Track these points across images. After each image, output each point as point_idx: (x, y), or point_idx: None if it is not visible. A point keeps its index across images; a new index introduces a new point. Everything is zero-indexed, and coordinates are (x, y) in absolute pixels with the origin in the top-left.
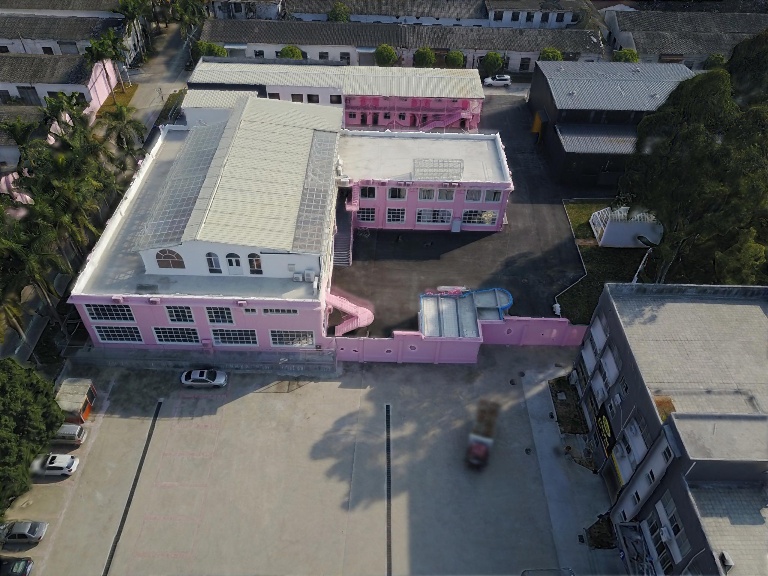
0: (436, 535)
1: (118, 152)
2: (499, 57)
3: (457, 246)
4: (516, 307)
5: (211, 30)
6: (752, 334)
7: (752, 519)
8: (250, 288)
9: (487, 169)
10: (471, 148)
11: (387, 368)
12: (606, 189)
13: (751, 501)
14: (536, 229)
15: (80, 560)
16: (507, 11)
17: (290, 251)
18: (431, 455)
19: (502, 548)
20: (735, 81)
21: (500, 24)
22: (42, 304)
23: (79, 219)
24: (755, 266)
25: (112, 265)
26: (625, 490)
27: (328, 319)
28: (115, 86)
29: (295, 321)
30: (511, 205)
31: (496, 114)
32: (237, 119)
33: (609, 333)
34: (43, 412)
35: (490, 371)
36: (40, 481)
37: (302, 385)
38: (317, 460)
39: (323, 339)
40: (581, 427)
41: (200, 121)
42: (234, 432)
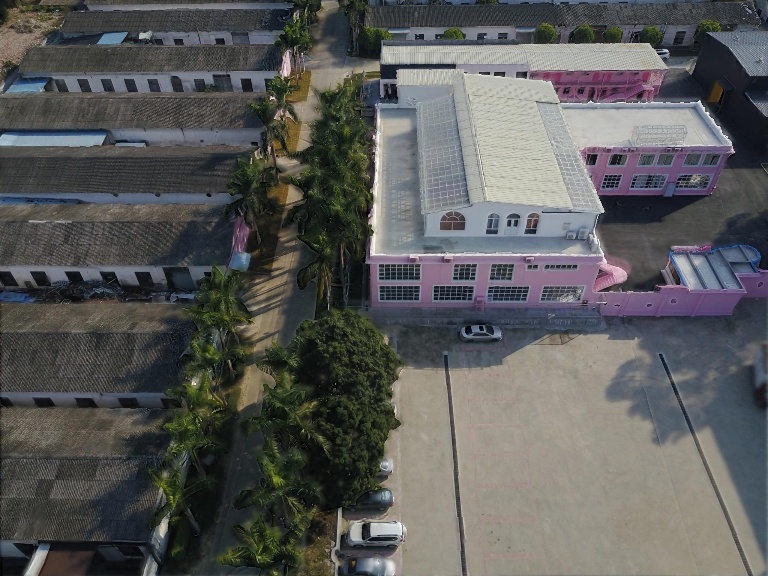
0: (753, 467)
1: (351, 129)
2: (658, 31)
3: (674, 209)
4: None
5: (373, 16)
6: None
7: None
8: (529, 246)
9: (700, 134)
10: (676, 116)
11: (647, 321)
12: None
13: None
14: (745, 192)
15: (431, 491)
16: None
17: (572, 210)
18: (720, 397)
19: None
20: None
21: (646, 0)
22: None
23: None
24: None
25: (390, 229)
26: None
27: None
28: (290, 73)
29: (571, 276)
30: None
31: (665, 86)
32: (463, 94)
33: None
34: None
35: (748, 322)
36: None
37: (573, 338)
38: (614, 403)
39: (592, 294)
40: None
41: None
42: (527, 380)
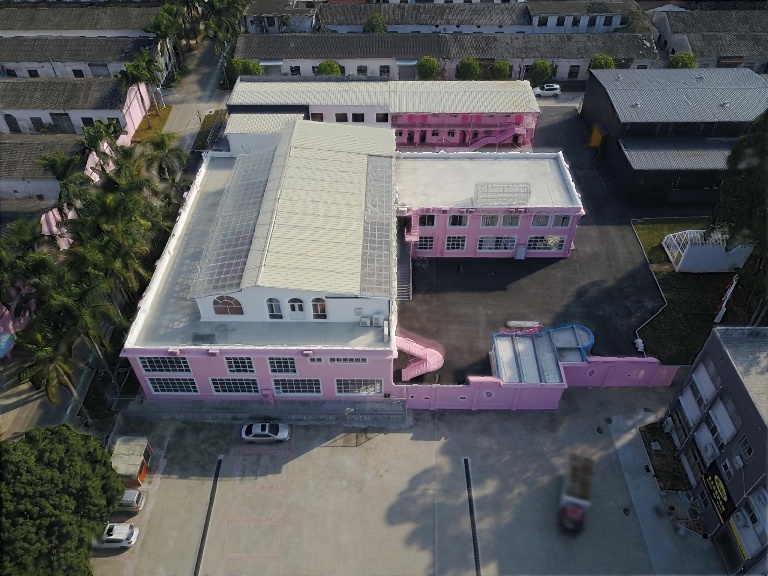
0: None
1: (162, 184)
2: (547, 66)
3: (523, 275)
4: (594, 343)
5: (245, 46)
6: None
7: None
8: (314, 335)
9: (553, 192)
10: (533, 168)
11: (461, 416)
12: (676, 207)
13: None
14: (606, 254)
15: None
16: (552, 16)
17: (358, 295)
18: (519, 518)
19: None
20: None
21: (544, 30)
22: (89, 351)
23: (128, 263)
24: None
25: (164, 311)
26: (754, 567)
27: (393, 362)
28: (149, 108)
29: (363, 370)
30: (576, 227)
31: (548, 127)
32: (286, 146)
33: (721, 384)
34: (103, 484)
35: (574, 418)
36: (98, 554)
37: (371, 437)
38: (395, 525)
39: (392, 387)
40: (682, 483)
41: (243, 146)
42: (302, 494)
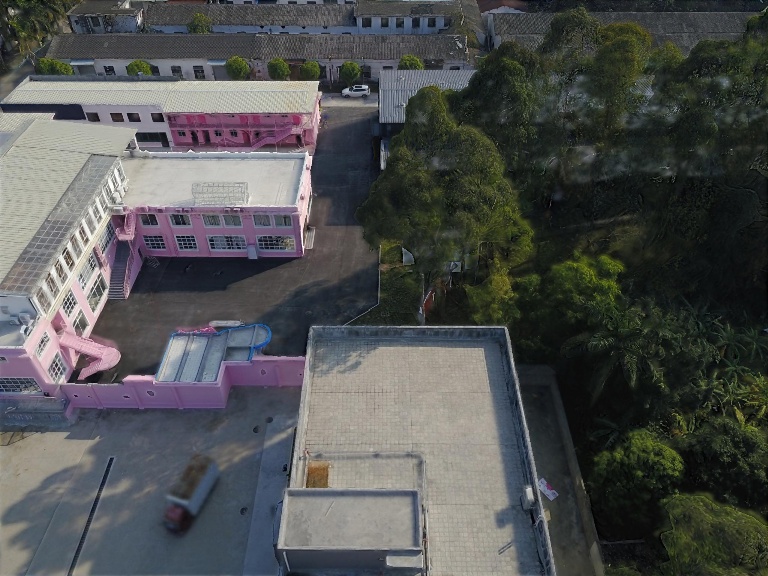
0: None
1: None
2: (355, 66)
3: (250, 275)
4: (288, 343)
5: (59, 46)
6: (459, 383)
7: None
8: None
9: (282, 191)
10: (275, 168)
11: (126, 415)
12: None
13: None
14: (341, 254)
15: None
16: (375, 17)
17: None
18: (137, 516)
19: None
20: (474, 97)
21: (370, 31)
22: None
23: None
24: (507, 300)
25: None
26: None
27: (77, 360)
28: None
29: (10, 368)
30: (324, 227)
31: (342, 127)
32: (9, 145)
33: None
34: None
35: (237, 417)
36: None
37: (26, 436)
38: (9, 524)
39: (49, 386)
40: None
41: None
42: None
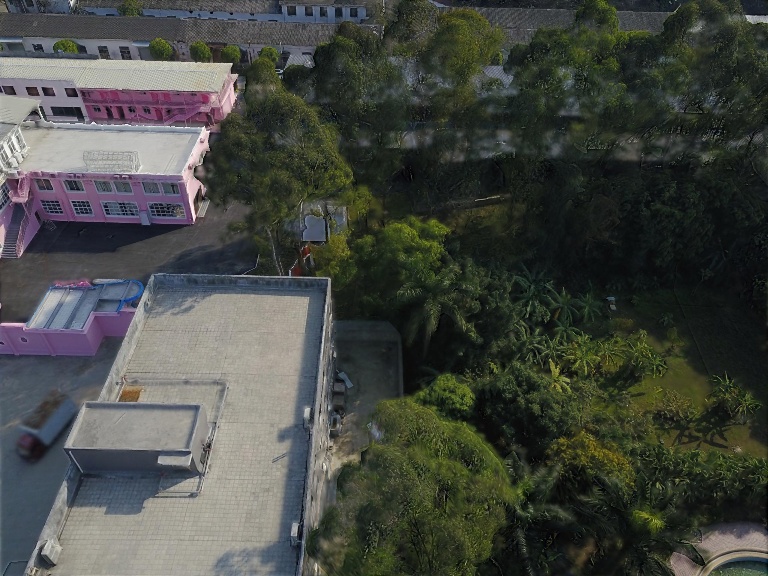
0: None
1: None
2: (274, 51)
3: (140, 239)
4: None
5: None
6: (279, 325)
7: (129, 509)
8: None
9: (173, 162)
10: (171, 141)
11: (2, 360)
12: None
13: (143, 491)
14: (230, 222)
15: None
16: (299, 6)
17: None
18: None
19: (10, 540)
20: (317, 71)
21: (295, 19)
22: None
23: None
24: (346, 258)
25: None
26: None
27: None
28: None
29: None
30: None
31: None
32: None
33: None
34: None
35: (104, 363)
36: None
37: None
38: None
39: None
40: None
41: None
42: None
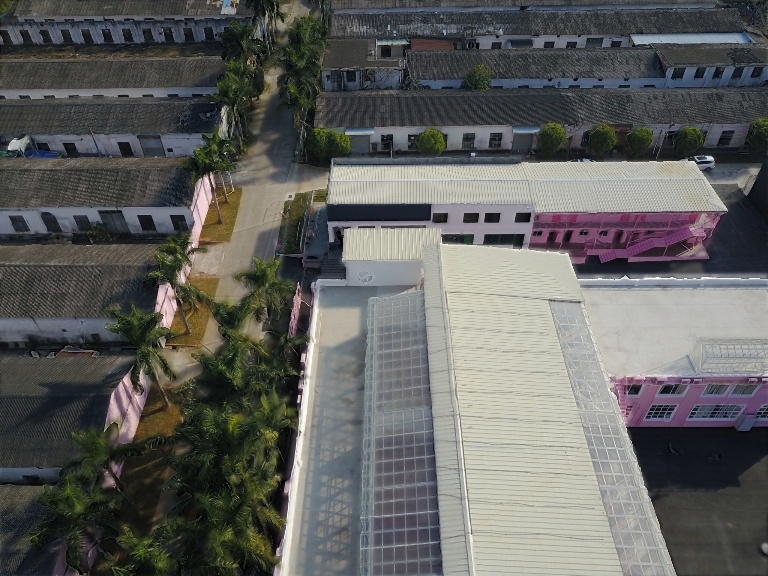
0: None
1: (269, 342)
2: (700, 134)
3: (755, 458)
4: None
5: (326, 111)
6: None
7: None
8: None
9: None
10: (750, 303)
11: None
12: None
13: None
14: None
15: None
16: (691, 67)
17: None
18: None
19: None
20: None
21: (679, 83)
22: None
23: (258, 512)
24: None
25: None
26: None
27: None
28: None
29: None
30: None
31: None
32: (438, 289)
33: None
34: None
35: None
36: None
37: None
38: None
39: None
40: None
41: None
42: None
